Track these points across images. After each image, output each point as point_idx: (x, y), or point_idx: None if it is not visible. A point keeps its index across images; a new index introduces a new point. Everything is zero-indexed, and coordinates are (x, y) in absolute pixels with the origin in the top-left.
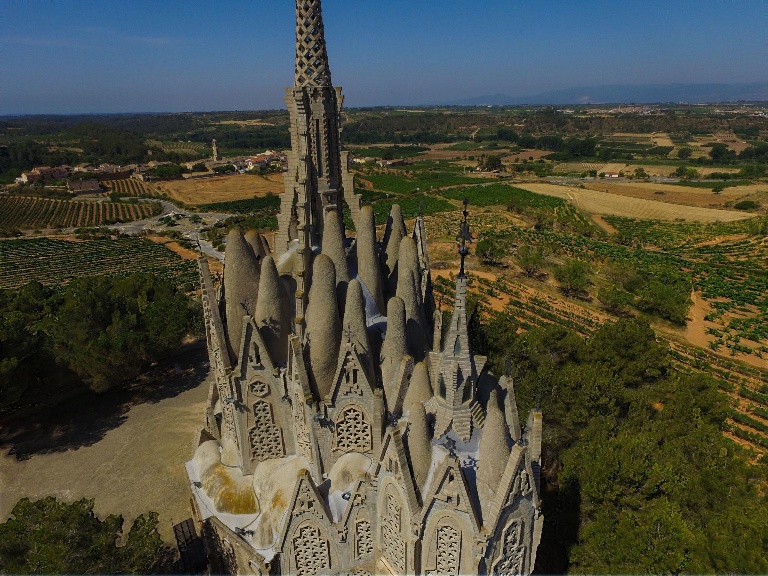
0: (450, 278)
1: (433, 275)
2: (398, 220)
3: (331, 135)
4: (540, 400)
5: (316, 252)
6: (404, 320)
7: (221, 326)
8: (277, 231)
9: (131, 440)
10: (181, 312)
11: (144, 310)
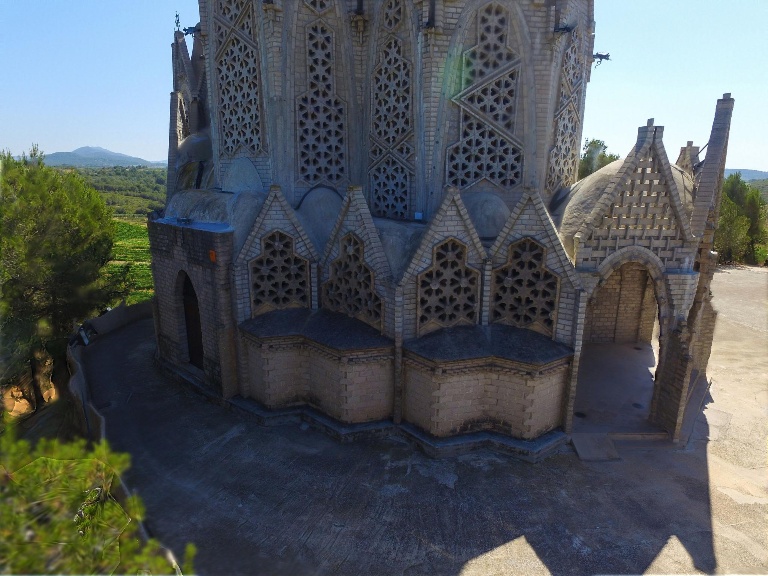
0: None
1: None
2: None
3: None
4: None
5: None
6: None
7: None
8: None
9: (767, 332)
10: None
11: None
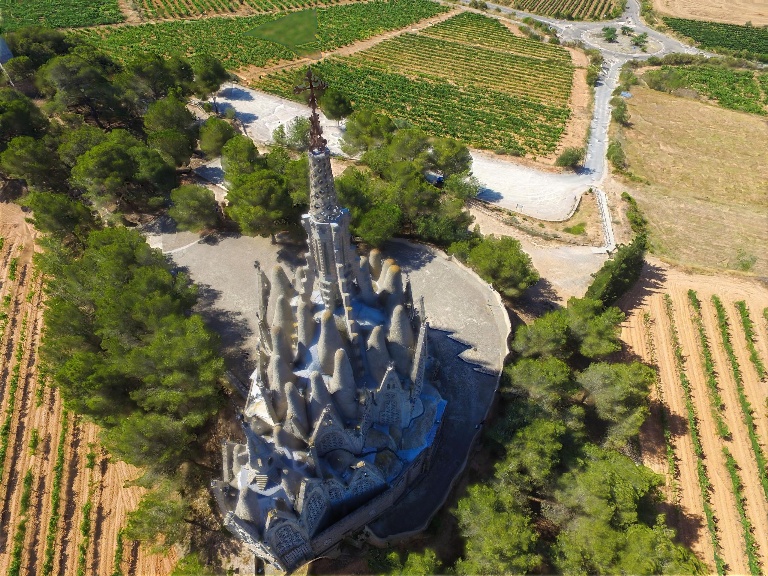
0: (763, 312)
1: (748, 293)
2: (396, 319)
3: (328, 252)
4: (486, 510)
5: (318, 307)
6: (291, 399)
7: (262, 310)
8: (701, 101)
9: None
10: (386, 224)
11: (379, 203)
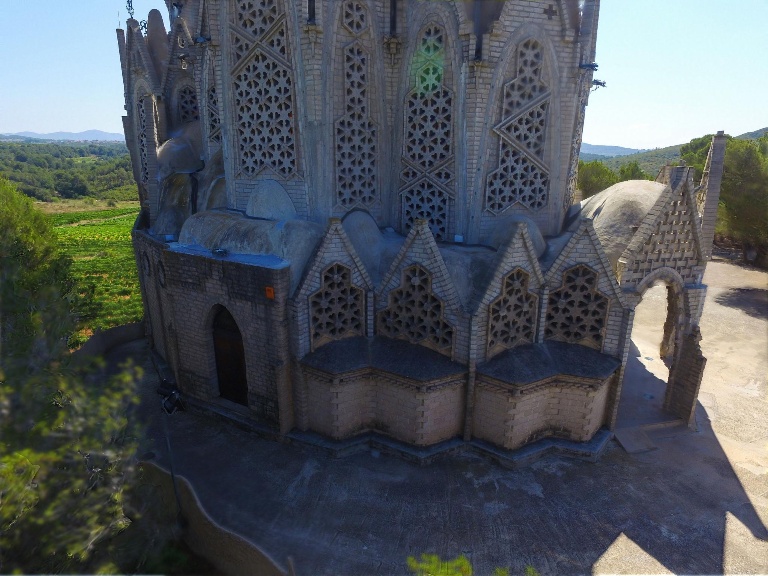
0: None
1: None
2: None
3: None
4: None
5: None
6: None
7: None
8: None
9: None
10: None
11: None
